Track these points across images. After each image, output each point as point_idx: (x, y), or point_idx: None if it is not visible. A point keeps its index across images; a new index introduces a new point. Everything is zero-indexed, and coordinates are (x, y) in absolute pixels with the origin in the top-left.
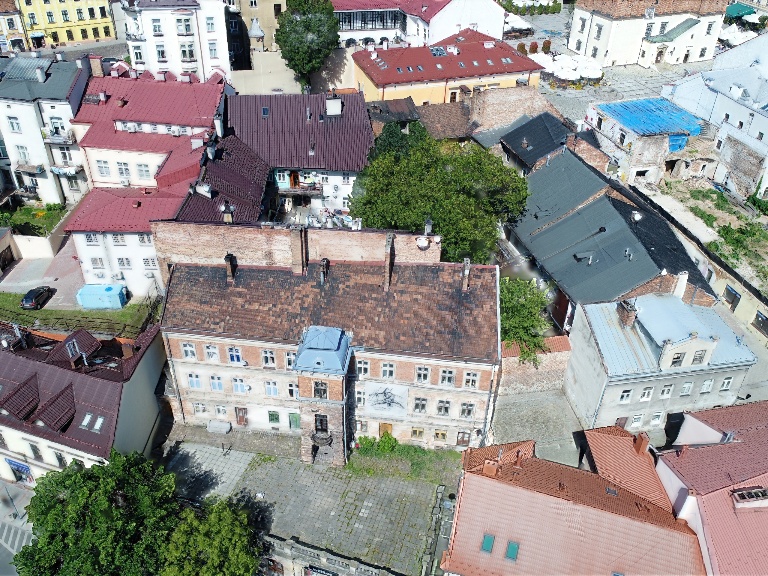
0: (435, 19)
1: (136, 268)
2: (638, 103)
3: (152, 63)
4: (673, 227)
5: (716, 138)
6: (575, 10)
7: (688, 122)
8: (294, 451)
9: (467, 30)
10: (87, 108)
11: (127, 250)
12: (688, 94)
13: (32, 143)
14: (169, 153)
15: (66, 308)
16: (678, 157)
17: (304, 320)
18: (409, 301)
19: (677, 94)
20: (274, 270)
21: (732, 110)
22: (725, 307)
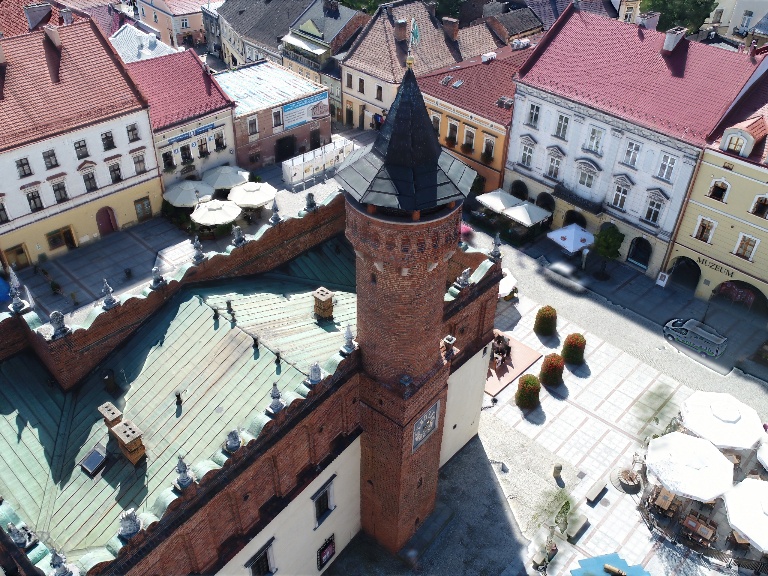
0: None
1: None
2: (268, 101)
3: None
4: None
5: None
6: None
7: None
8: None
9: None
10: None
11: None
12: None
13: None
14: None
15: None
16: None
17: None
18: None
19: None
20: None
21: None
22: None
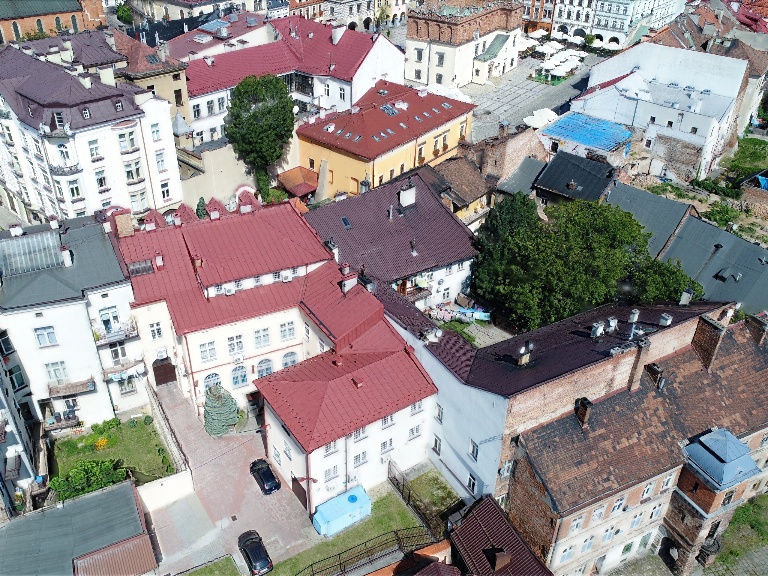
0: (356, 77)
1: (372, 458)
2: (565, 121)
3: (91, 196)
4: None
5: (645, 139)
6: (407, 42)
7: (620, 130)
8: (660, 573)
9: (382, 82)
10: (141, 282)
11: (367, 442)
12: (602, 105)
13: (75, 353)
14: (302, 305)
15: (302, 548)
16: (628, 162)
17: (673, 435)
18: (732, 374)
19: (589, 107)
20: (613, 396)
21: (658, 113)
22: None
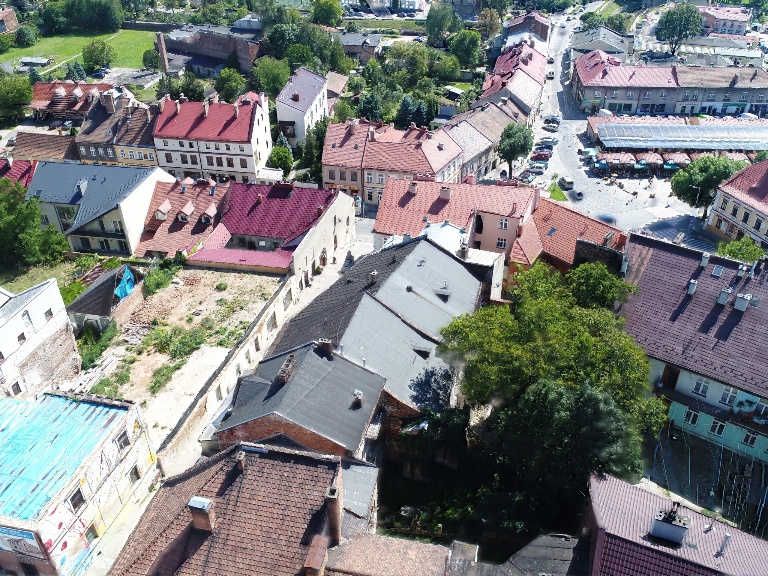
0: None
1: None
2: None
3: None
4: (223, 375)
5: None
6: None
7: (6, 409)
8: None
9: None
10: None
11: None
12: None
13: None
14: None
15: None
16: None
17: None
18: None
19: None
20: None
21: None
22: (276, 333)
